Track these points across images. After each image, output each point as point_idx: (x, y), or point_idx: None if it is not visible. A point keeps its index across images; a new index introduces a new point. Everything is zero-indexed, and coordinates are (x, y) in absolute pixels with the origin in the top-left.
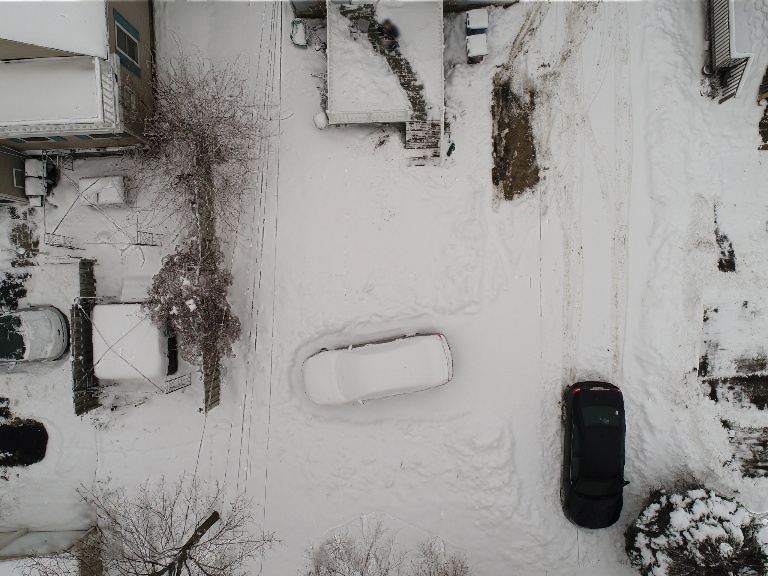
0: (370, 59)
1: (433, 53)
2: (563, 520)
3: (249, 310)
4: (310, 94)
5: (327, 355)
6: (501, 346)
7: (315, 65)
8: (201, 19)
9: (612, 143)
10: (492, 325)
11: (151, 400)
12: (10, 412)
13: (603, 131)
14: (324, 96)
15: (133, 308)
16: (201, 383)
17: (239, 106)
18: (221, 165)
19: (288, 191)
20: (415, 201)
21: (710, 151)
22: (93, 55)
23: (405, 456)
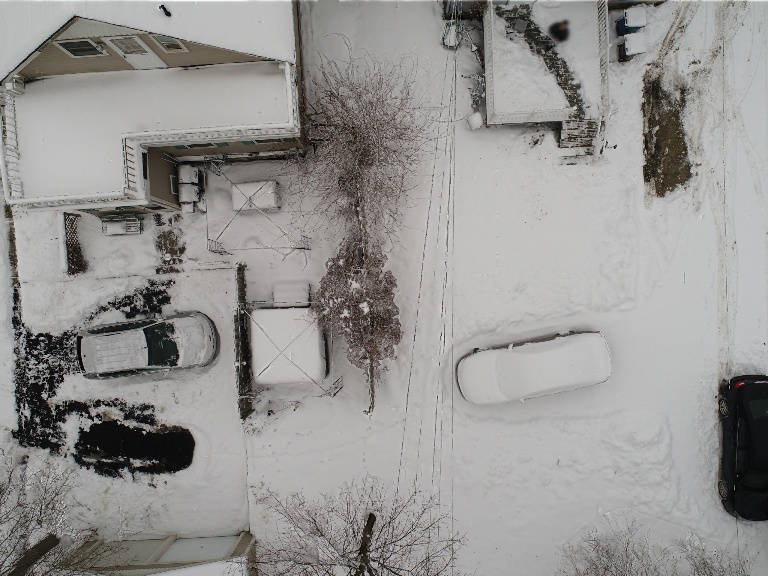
0: (528, 59)
1: (592, 52)
2: (722, 513)
3: (401, 312)
4: (460, 95)
5: (486, 355)
6: (656, 342)
7: (465, 66)
8: (348, 22)
9: (764, 138)
10: (647, 321)
11: (303, 404)
12: (155, 419)
13: (755, 126)
14: (477, 97)
15: (292, 312)
16: (353, 386)
17: (404, 108)
18: (372, 168)
19: (438, 192)
20: (567, 200)
21: None
22: (284, 60)
23: (562, 454)
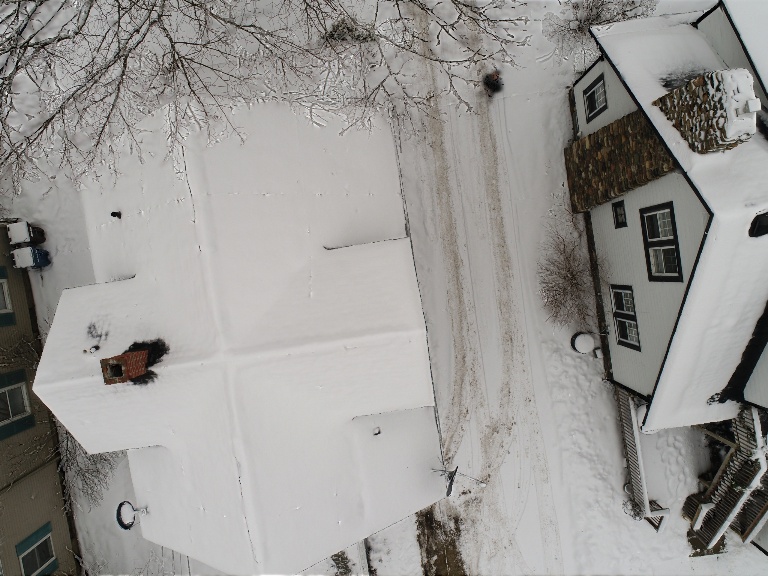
0: None
1: None
2: None
3: None
4: None
5: None
6: None
7: None
8: None
9: (542, 564)
10: None
11: None
12: None
13: (532, 552)
14: None
15: None
16: None
17: None
18: None
19: None
20: None
21: (641, 565)
22: None
23: None
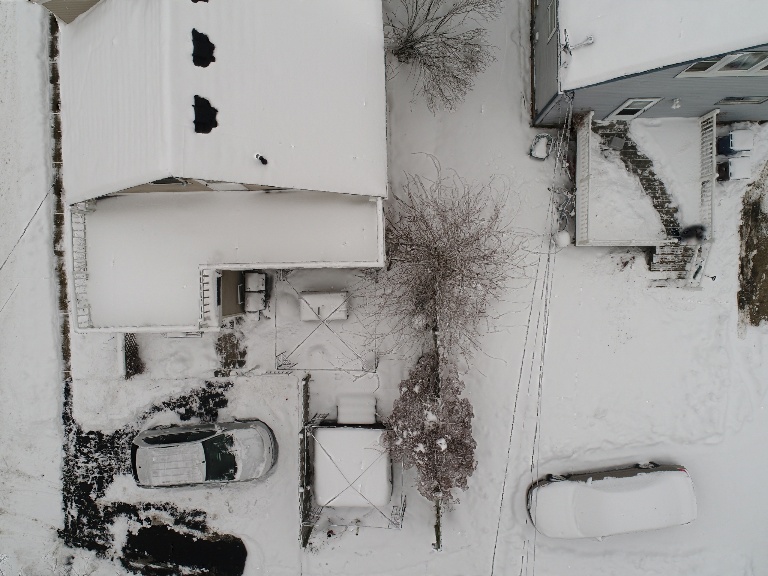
0: (624, 180)
1: (693, 175)
2: None
3: None
4: (545, 208)
5: (562, 487)
6: (743, 479)
7: (551, 178)
8: (429, 125)
9: None
10: (734, 457)
11: (364, 523)
12: (207, 526)
13: None
14: (564, 213)
15: (360, 434)
16: (417, 506)
17: (491, 231)
18: (448, 281)
19: (516, 308)
20: (654, 324)
21: None
22: (376, 195)
23: None
